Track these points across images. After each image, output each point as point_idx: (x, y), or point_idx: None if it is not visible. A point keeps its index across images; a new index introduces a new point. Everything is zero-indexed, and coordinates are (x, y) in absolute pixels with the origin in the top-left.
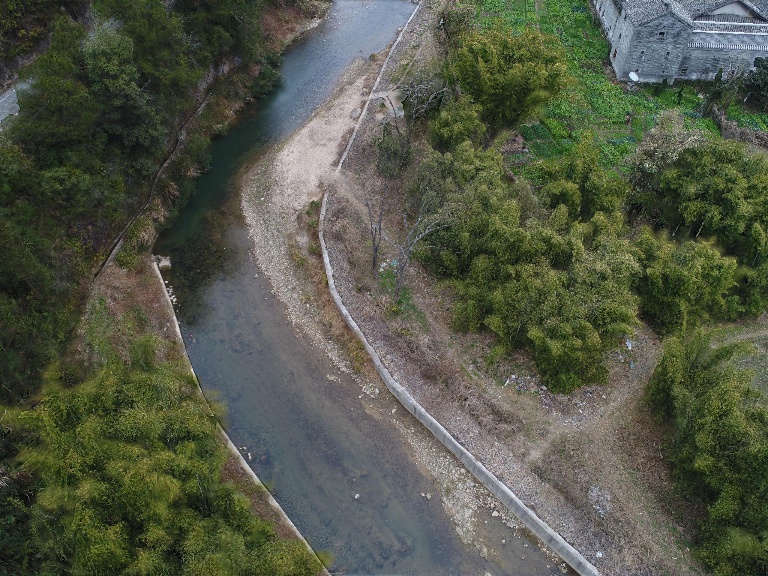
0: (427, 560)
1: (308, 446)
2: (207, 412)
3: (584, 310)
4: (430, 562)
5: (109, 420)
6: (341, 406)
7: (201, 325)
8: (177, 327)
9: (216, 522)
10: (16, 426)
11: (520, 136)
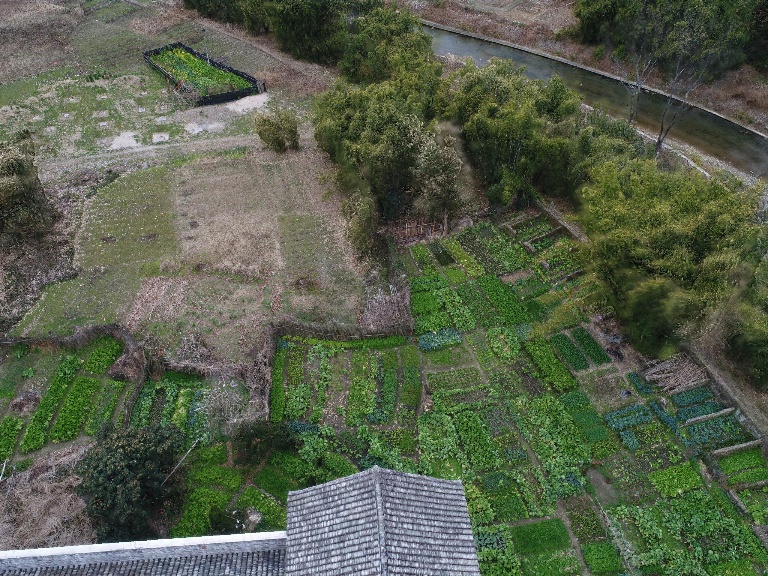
0: (537, 74)
1: (621, 99)
2: (689, 101)
3: (497, 66)
4: (535, 74)
5: (707, 2)
6: (616, 112)
7: (750, 142)
8: (763, 134)
9: (632, 3)
10: (753, 24)
11: (598, 330)
